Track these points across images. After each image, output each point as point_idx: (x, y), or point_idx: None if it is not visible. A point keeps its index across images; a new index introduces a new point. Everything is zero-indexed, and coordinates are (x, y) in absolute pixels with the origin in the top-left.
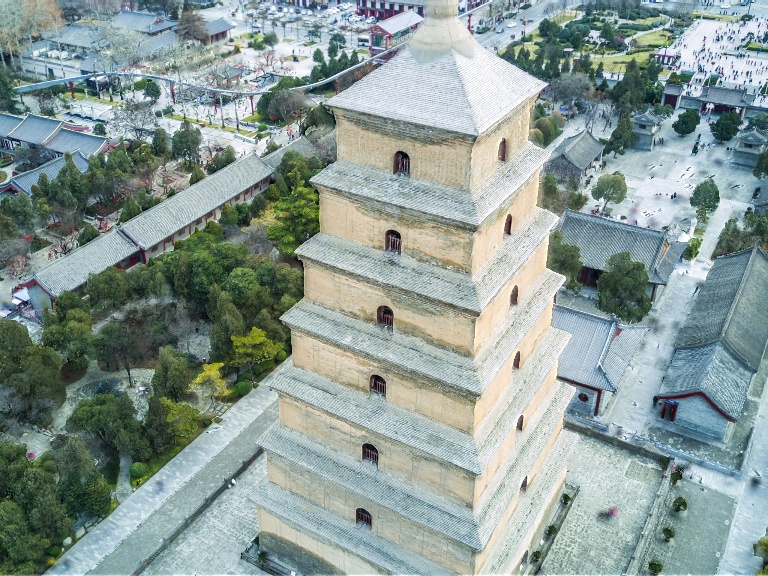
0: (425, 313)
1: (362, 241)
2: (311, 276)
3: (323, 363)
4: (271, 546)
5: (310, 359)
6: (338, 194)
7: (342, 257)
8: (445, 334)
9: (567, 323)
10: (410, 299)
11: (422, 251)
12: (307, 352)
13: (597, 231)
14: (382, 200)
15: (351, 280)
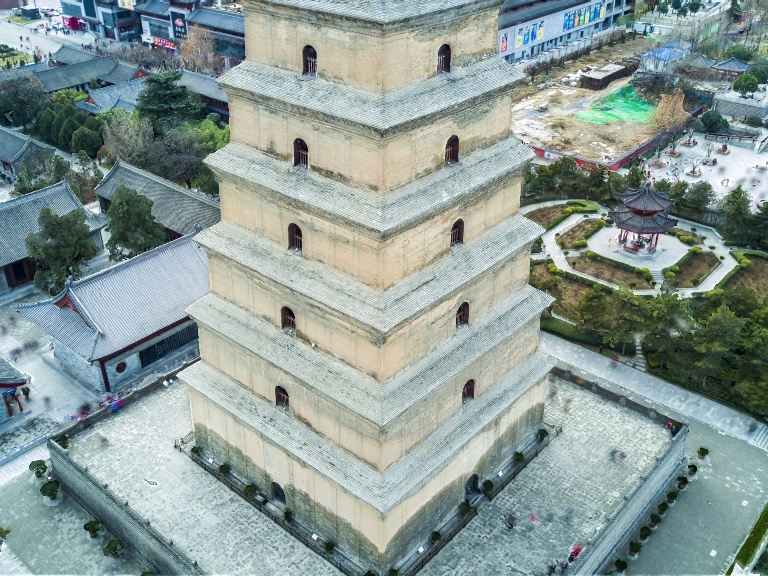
0: (481, 116)
1: (419, 77)
2: (389, 155)
3: (413, 255)
4: (396, 552)
5: (400, 264)
6: (402, 28)
7: (420, 103)
8: (494, 127)
9: (169, 261)
10: (472, 109)
11: (465, 54)
12: (398, 257)
13: (5, 219)
14: (448, 7)
15: (426, 127)
